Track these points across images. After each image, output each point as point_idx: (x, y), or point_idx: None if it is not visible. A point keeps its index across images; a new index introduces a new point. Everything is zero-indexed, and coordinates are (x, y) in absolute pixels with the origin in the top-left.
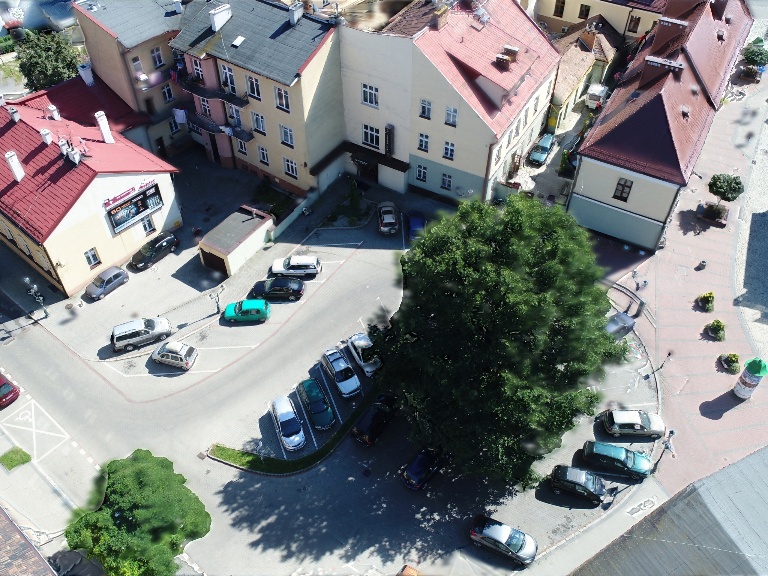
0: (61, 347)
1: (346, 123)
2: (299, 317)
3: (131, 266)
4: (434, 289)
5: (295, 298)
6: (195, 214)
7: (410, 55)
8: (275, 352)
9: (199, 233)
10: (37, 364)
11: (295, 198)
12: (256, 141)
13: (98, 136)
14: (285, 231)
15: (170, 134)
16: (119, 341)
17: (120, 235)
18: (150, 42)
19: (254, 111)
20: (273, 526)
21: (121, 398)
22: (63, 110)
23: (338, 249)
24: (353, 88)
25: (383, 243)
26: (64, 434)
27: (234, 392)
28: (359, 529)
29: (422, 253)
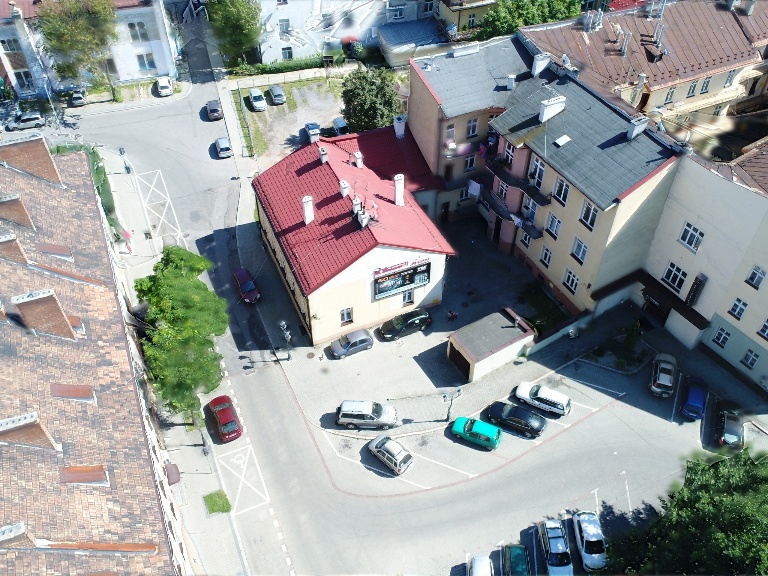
0: (291, 397)
1: (650, 252)
2: (529, 460)
3: (379, 332)
4: (715, 571)
5: (531, 435)
6: (456, 294)
7: (761, 215)
8: (491, 492)
9: (454, 318)
10: (266, 407)
11: (564, 312)
12: (543, 240)
13: (391, 195)
14: (543, 349)
15: (458, 200)
16: (344, 417)
17: (379, 301)
18: (471, 113)
19: (553, 213)
20: None
21: (327, 478)
22: (367, 157)
23: (595, 392)
24: (673, 222)
25: (649, 404)
26: (266, 496)
27: (436, 522)
28: None
29: (709, 503)
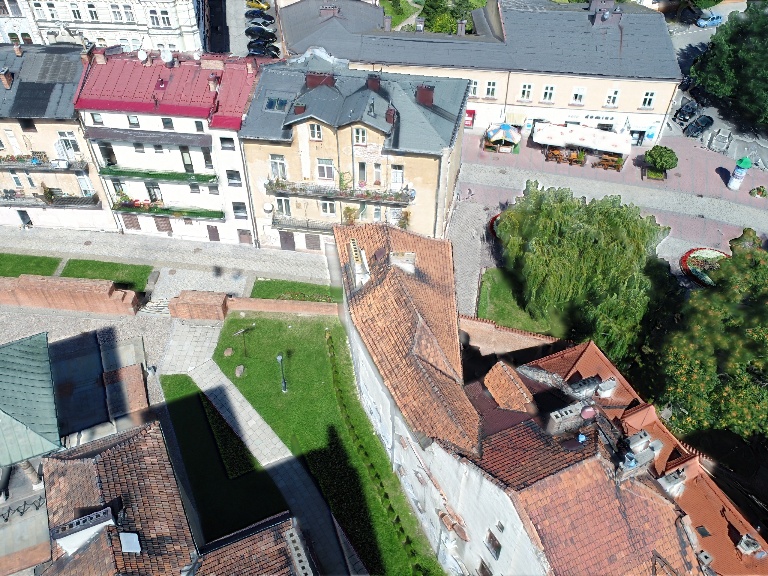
0: None
1: None
2: None
3: None
4: None
5: None
6: None
7: None
8: None
9: None
10: None
11: None
12: None
13: None
14: None
15: None
16: None
17: None
18: None
19: None
20: (697, 49)
21: None
22: None
23: None
24: None
25: None
26: None
27: None
28: (688, 62)
29: None
